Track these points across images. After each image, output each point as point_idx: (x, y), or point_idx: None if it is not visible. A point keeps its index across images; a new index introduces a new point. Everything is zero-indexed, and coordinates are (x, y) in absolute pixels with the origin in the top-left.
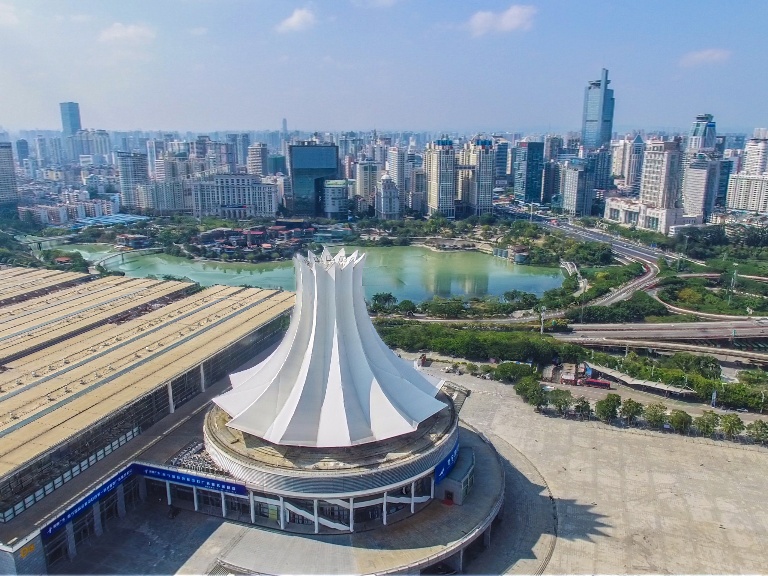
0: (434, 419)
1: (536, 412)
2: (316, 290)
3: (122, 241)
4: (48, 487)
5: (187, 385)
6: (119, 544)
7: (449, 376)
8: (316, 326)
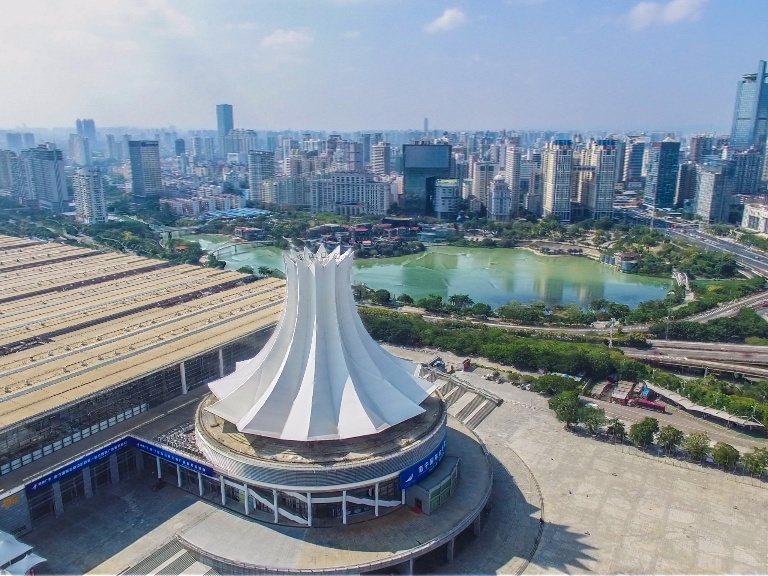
0: (414, 424)
1: (565, 429)
2: (298, 285)
3: (239, 233)
4: (47, 449)
5: (203, 369)
6: (102, 508)
7: (488, 383)
8: (297, 321)
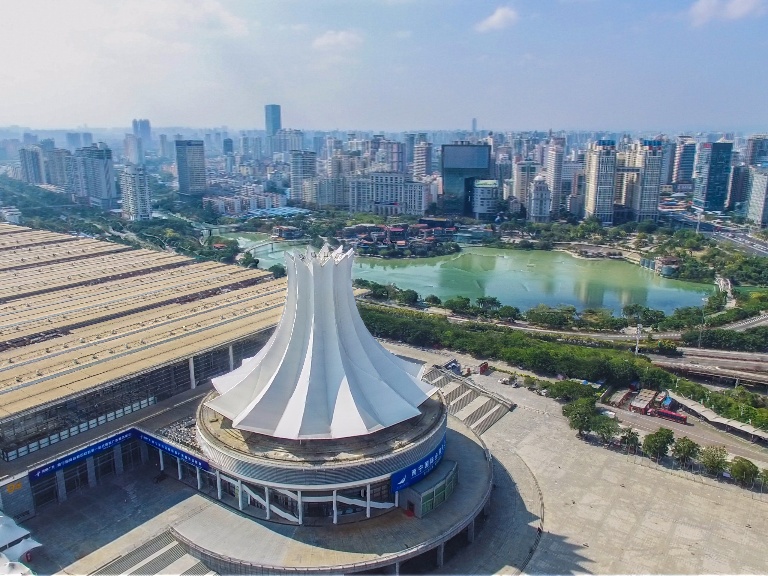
0: (411, 426)
1: (577, 437)
2: (297, 284)
3: (277, 232)
4: (54, 437)
5: (213, 365)
6: (103, 497)
7: (503, 387)
8: (296, 319)
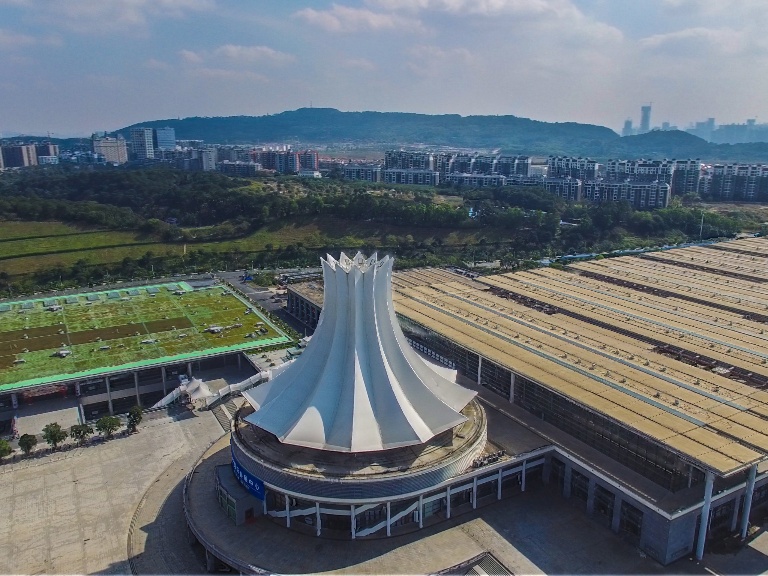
0: (261, 436)
1: None
2: None
3: None
4: None
5: None
6: None
7: None
8: None
